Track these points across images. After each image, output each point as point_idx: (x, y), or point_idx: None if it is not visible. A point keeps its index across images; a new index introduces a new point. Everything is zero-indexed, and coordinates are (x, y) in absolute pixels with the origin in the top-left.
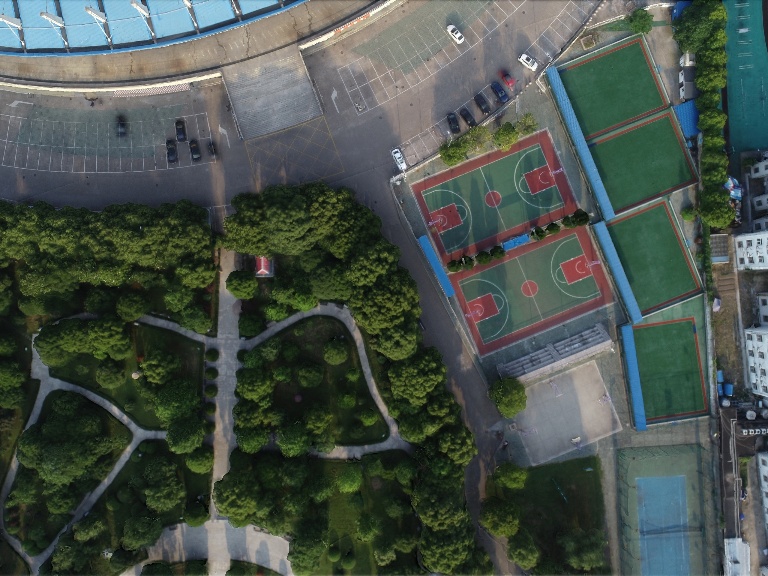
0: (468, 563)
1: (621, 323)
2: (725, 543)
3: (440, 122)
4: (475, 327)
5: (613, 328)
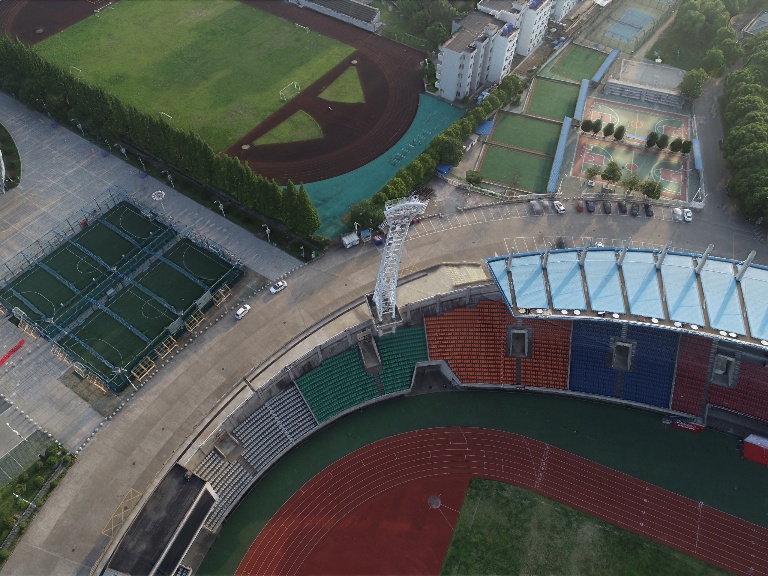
0: (764, 40)
1: (592, 89)
2: (605, 5)
3: (643, 217)
4: (684, 128)
5: (598, 89)
